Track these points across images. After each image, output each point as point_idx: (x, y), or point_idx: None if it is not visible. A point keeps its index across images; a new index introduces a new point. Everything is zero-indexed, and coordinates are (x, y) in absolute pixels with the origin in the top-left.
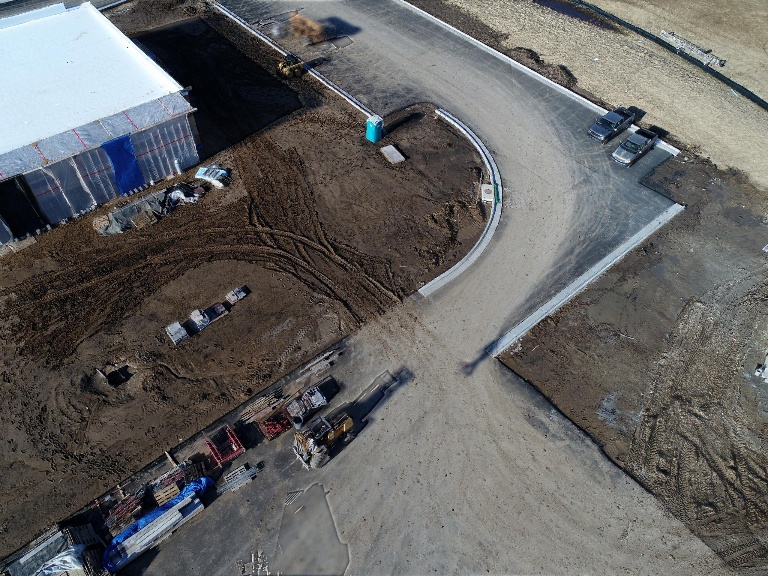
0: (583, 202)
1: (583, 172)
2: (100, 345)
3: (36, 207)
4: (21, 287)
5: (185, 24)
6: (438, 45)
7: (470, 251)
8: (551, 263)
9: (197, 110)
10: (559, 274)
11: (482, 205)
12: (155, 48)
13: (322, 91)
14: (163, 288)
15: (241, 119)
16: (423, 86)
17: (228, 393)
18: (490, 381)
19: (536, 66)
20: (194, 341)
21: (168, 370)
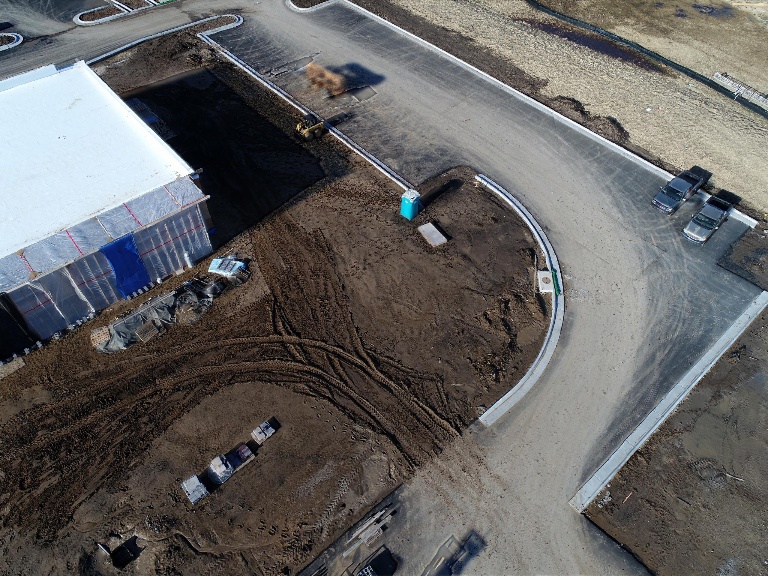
0: (657, 292)
1: (651, 252)
2: (102, 508)
3: (23, 325)
4: (6, 428)
5: (189, 76)
6: (470, 95)
7: (534, 362)
8: (631, 376)
9: (207, 184)
10: (642, 391)
11: (541, 298)
12: (157, 107)
13: (346, 155)
14: (176, 424)
15: (257, 194)
16: (458, 146)
17: (260, 575)
18: (579, 548)
19: (582, 119)
20: (216, 499)
21: (185, 542)
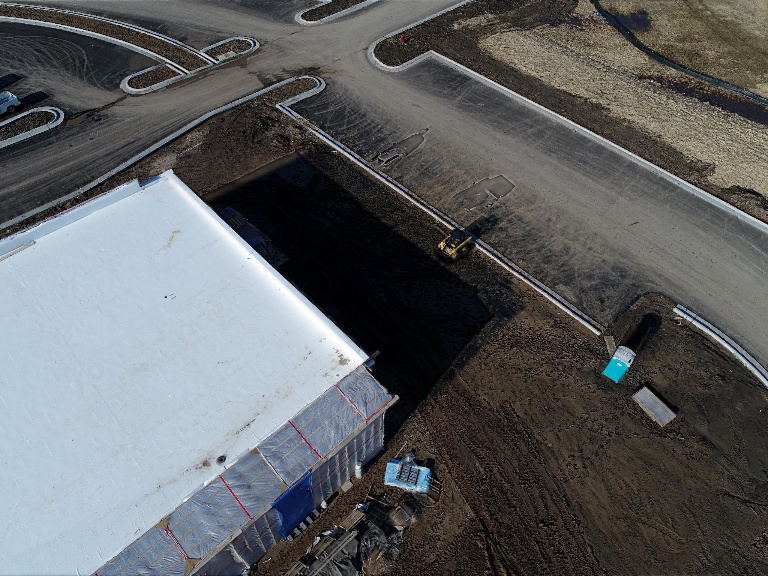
0: None
1: None
2: None
3: None
4: None
5: (282, 167)
6: (627, 186)
7: None
8: None
9: None
10: None
11: None
12: (254, 215)
13: (506, 281)
14: None
15: (414, 348)
16: (638, 262)
17: None
18: None
19: None
20: None
21: None
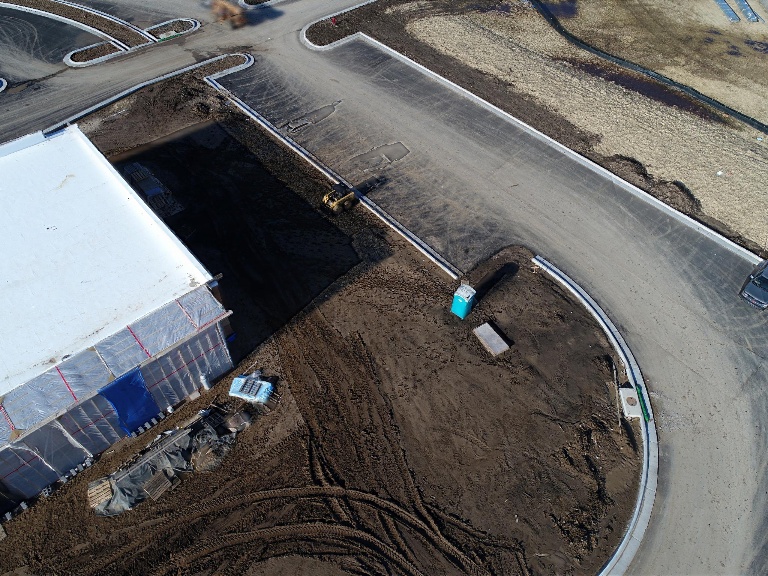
0: (763, 416)
1: (749, 360)
2: None
3: (4, 490)
4: None
5: (197, 131)
6: (516, 153)
7: (632, 521)
8: (751, 539)
9: None
10: None
11: (627, 425)
12: (161, 171)
13: (381, 232)
14: None
15: (282, 285)
16: (509, 219)
17: None
18: None
19: (645, 184)
20: None
21: None
